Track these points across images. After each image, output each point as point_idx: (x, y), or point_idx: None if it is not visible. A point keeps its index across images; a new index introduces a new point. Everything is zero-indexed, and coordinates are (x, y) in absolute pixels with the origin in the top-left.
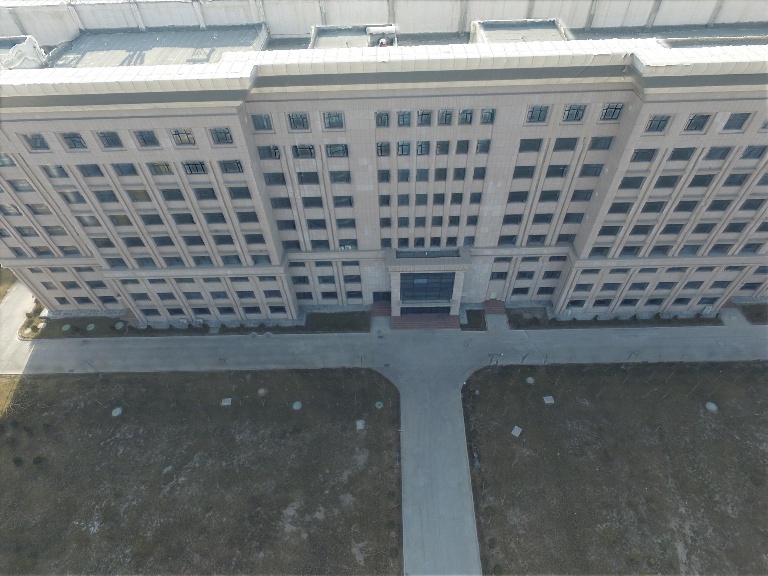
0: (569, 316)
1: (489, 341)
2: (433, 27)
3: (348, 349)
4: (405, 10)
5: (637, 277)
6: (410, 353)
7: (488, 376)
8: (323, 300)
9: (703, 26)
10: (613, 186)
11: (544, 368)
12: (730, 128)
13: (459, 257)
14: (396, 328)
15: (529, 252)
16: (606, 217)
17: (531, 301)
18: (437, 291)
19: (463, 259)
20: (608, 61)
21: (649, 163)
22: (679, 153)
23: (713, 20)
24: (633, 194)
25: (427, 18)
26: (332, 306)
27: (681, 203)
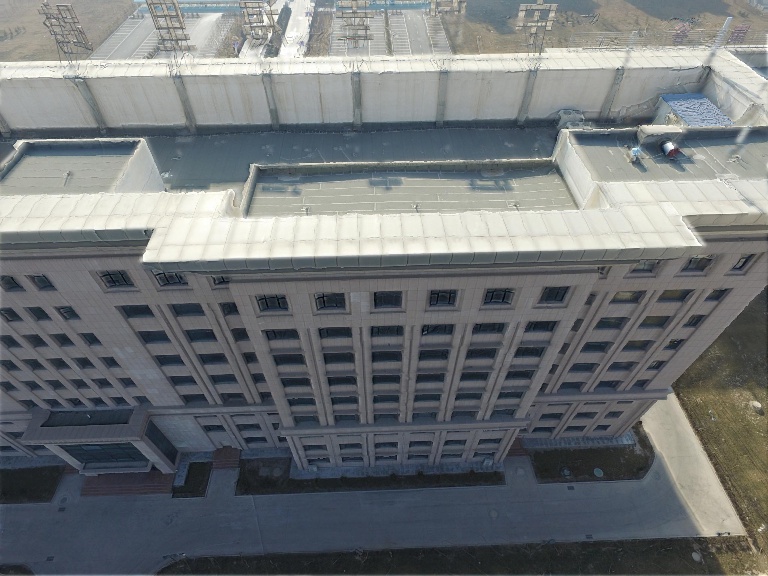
0: (316, 472)
1: (201, 514)
2: (61, 121)
3: (10, 531)
4: (8, 100)
5: (377, 438)
6: (89, 537)
7: (177, 575)
8: (3, 452)
9: (431, 123)
10: (265, 364)
11: (255, 561)
12: (388, 304)
13: (126, 424)
14: (87, 494)
15: (232, 410)
16: (286, 390)
17: (276, 448)
18: (125, 454)
19: (129, 428)
20: (126, 237)
21: (298, 341)
22: (334, 330)
23: (441, 117)
24: (303, 369)
25: (46, 110)
26: (18, 458)
27: (379, 375)
